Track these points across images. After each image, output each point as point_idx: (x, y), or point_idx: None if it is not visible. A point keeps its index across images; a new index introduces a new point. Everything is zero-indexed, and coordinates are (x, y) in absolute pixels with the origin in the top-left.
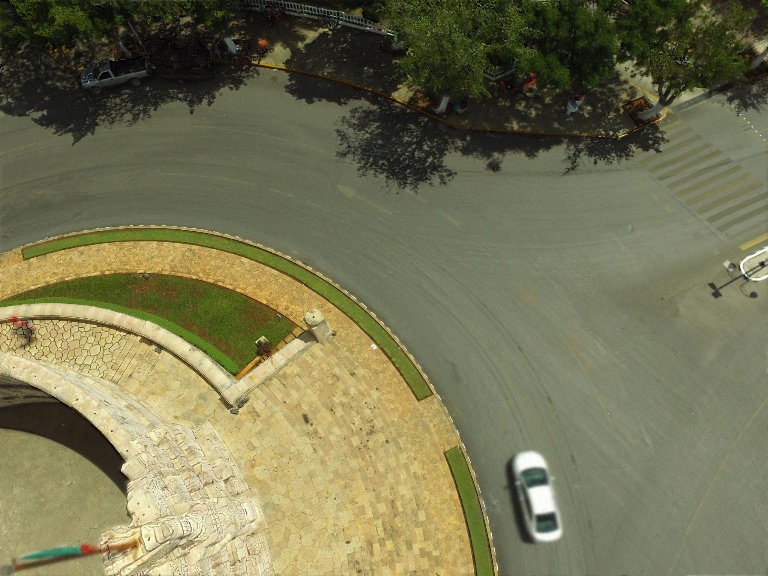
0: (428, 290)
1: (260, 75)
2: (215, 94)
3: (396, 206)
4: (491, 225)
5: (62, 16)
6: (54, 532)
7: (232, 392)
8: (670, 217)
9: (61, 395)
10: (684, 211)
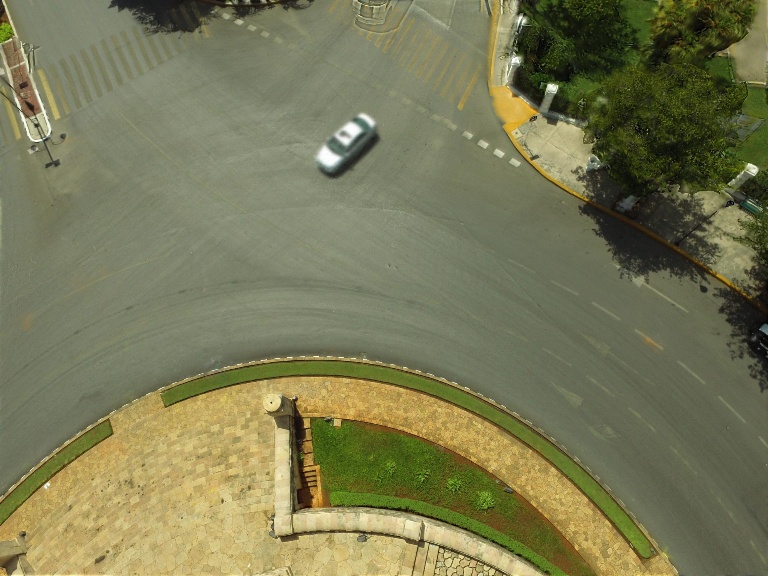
0: None
1: None
2: None
3: None
4: None
5: None
6: None
7: None
8: None
9: None
10: None
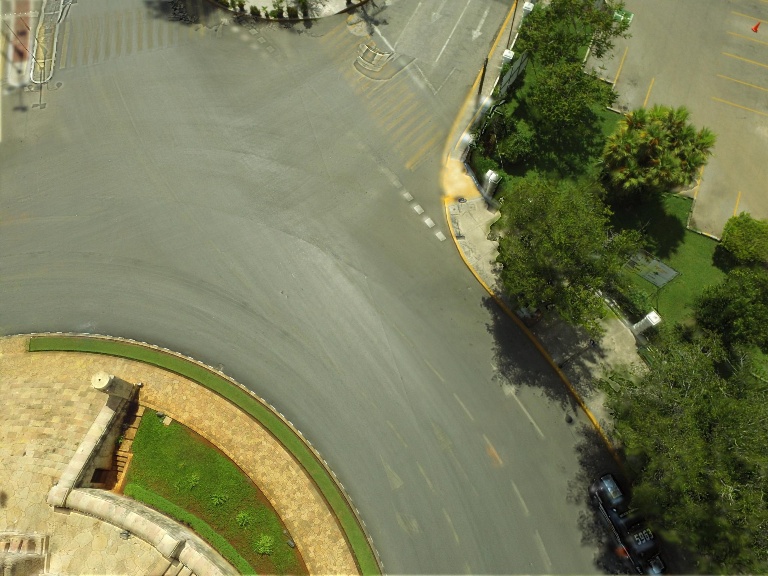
0: None
1: None
2: None
3: None
4: None
5: None
6: None
7: None
8: None
9: None
10: None
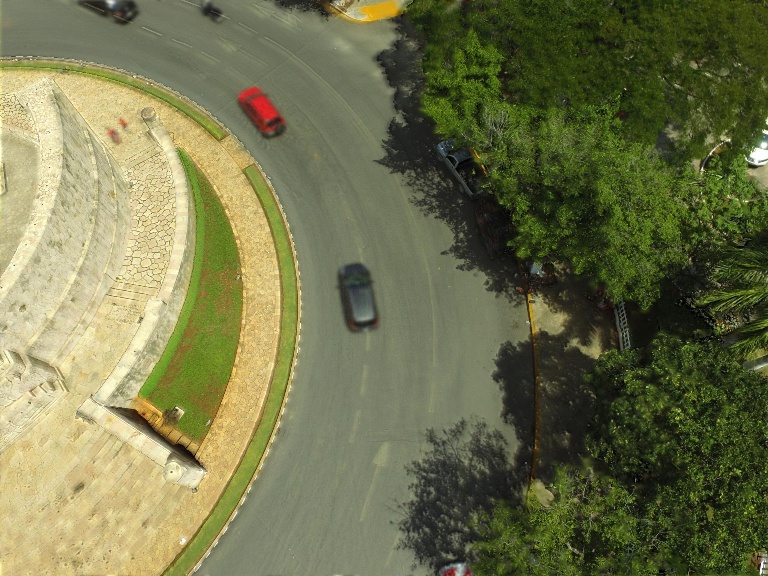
0: None
1: (515, 308)
2: (474, 269)
3: (373, 525)
4: None
5: (439, 112)
6: None
7: (87, 408)
8: None
9: (7, 272)
10: None
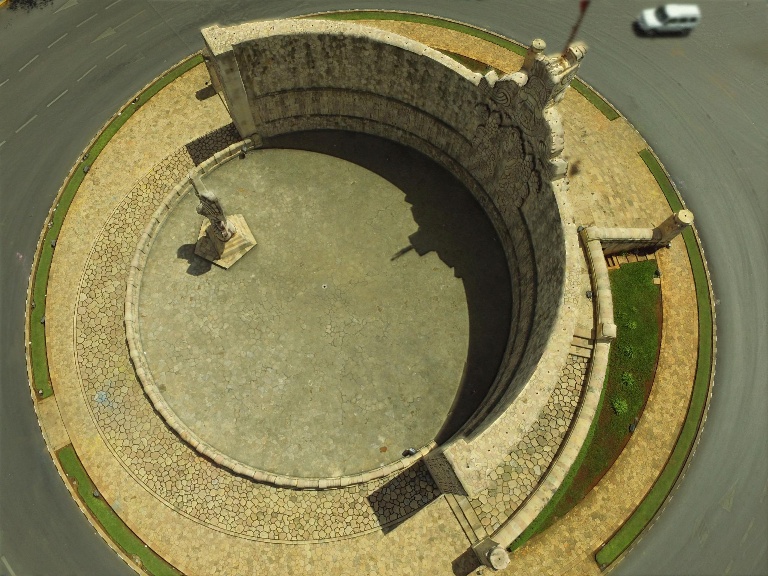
0: (600, 49)
1: None
2: None
3: None
4: (639, 4)
5: None
6: (350, 214)
7: None
8: None
9: (412, 48)
10: None
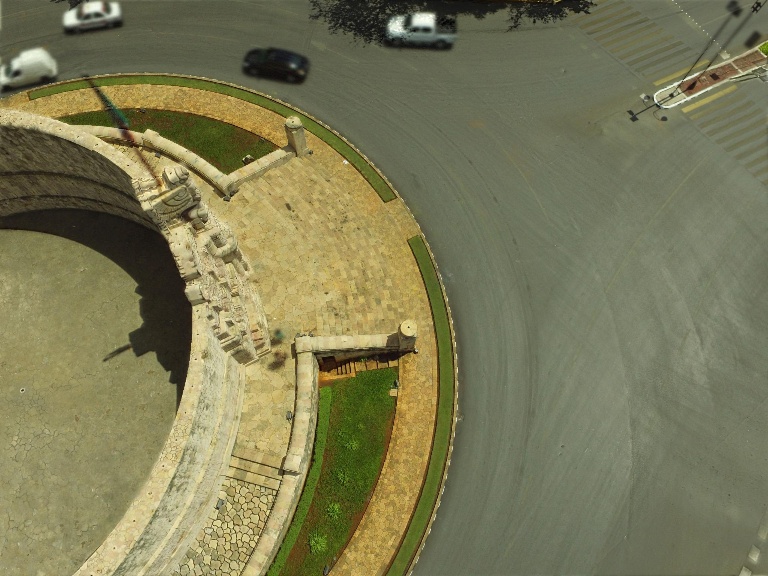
0: (392, 120)
1: None
2: None
3: (363, 57)
4: (445, 70)
5: None
6: (71, 306)
7: (225, 179)
8: (596, 62)
9: (83, 142)
10: (608, 57)
